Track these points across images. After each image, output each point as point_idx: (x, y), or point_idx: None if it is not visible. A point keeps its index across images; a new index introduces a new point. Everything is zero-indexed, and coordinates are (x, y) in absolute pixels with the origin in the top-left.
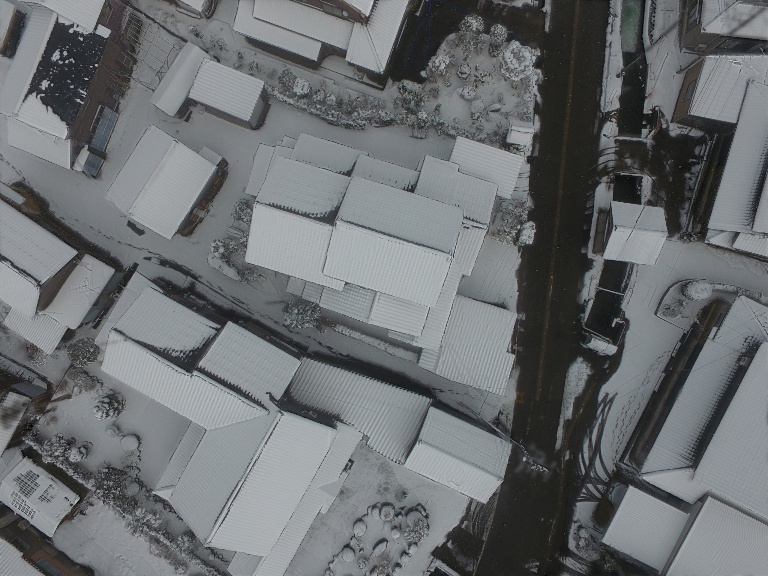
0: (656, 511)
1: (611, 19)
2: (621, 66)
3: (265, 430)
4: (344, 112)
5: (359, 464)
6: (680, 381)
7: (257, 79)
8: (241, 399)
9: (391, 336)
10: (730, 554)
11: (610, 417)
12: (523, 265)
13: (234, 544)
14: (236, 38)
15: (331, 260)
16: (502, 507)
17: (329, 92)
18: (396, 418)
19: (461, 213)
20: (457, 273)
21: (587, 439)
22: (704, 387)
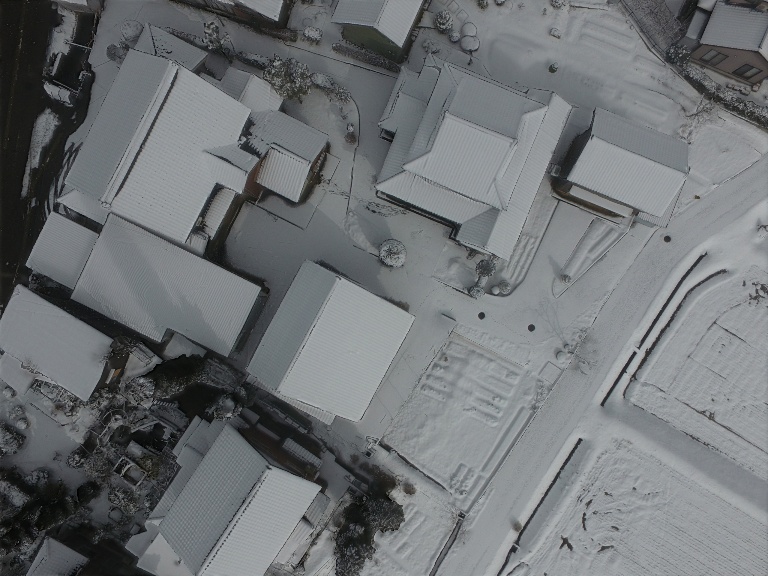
0: (74, 234)
1: None
2: None
3: None
4: None
5: None
6: None
7: None
8: None
9: None
10: None
11: None
12: None
13: None
14: None
15: None
16: None
17: None
18: None
19: None
20: None
21: (53, 187)
22: None
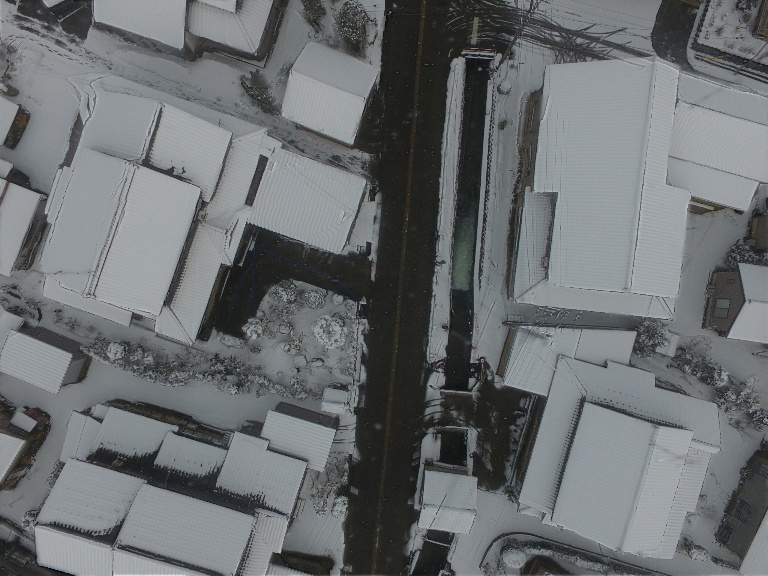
0: None
1: (436, 269)
2: (447, 316)
3: None
4: (163, 371)
5: None
6: None
7: (64, 352)
8: None
9: None
10: None
11: None
12: (349, 517)
13: None
14: None
15: (118, 574)
16: None
17: (151, 345)
18: None
19: (250, 523)
20: (266, 552)
21: None
22: None
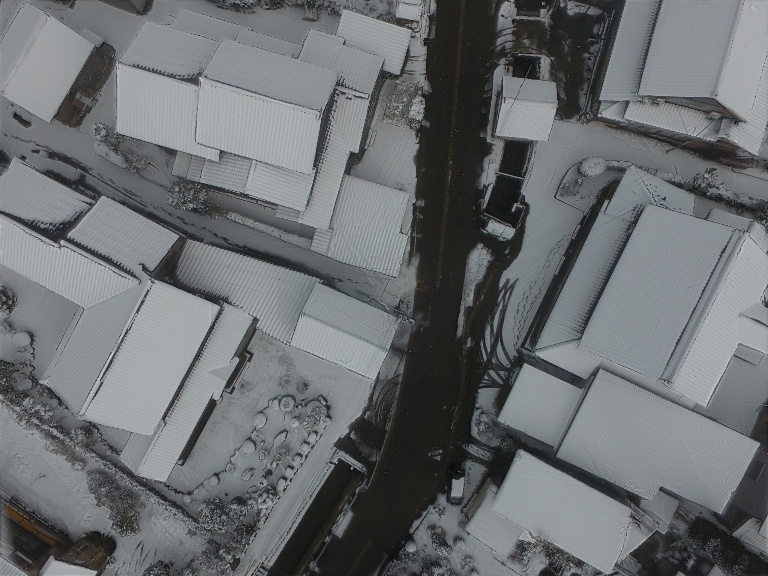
0: (550, 387)
1: None
2: None
3: (136, 300)
4: None
5: (259, 357)
6: None
7: None
8: (111, 269)
9: (278, 216)
10: (615, 418)
11: (511, 303)
12: (421, 150)
13: (111, 419)
14: None
15: (201, 125)
16: (404, 396)
17: None
18: (286, 299)
19: (335, 75)
20: (344, 149)
21: (488, 326)
22: (595, 259)
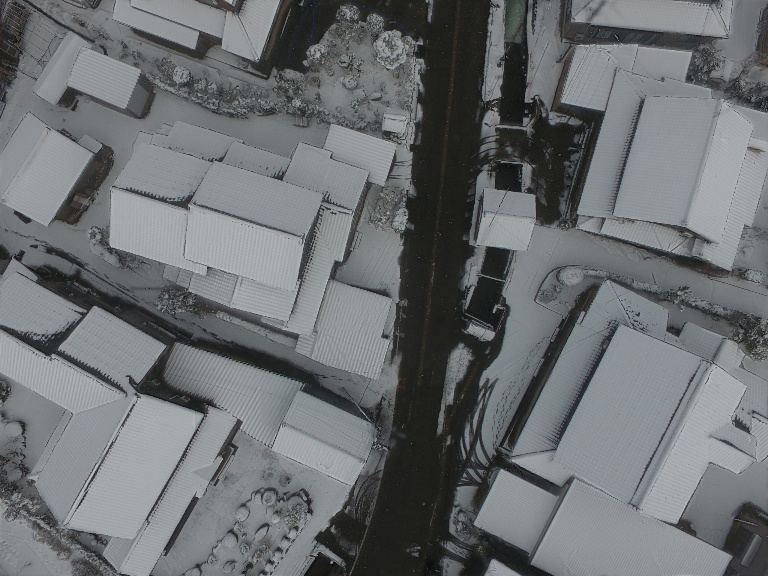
0: (526, 494)
1: (492, 9)
2: (502, 56)
3: (122, 412)
4: (226, 101)
5: (243, 450)
6: (553, 366)
7: (134, 67)
8: (99, 382)
9: (264, 321)
10: (587, 534)
11: (491, 402)
12: (405, 252)
13: (95, 526)
14: (122, 28)
15: (190, 244)
16: (384, 492)
17: (213, 81)
18: (269, 402)
19: (319, 198)
20: (329, 259)
21: (468, 424)
22: (571, 371)
